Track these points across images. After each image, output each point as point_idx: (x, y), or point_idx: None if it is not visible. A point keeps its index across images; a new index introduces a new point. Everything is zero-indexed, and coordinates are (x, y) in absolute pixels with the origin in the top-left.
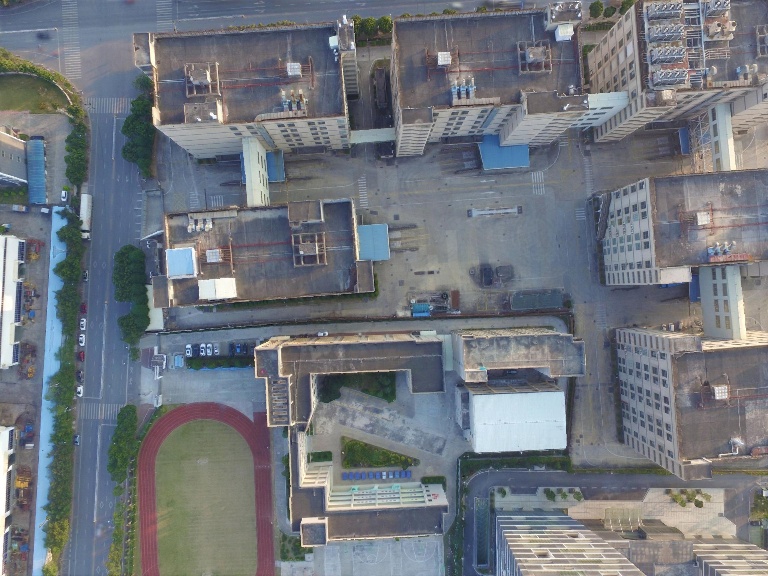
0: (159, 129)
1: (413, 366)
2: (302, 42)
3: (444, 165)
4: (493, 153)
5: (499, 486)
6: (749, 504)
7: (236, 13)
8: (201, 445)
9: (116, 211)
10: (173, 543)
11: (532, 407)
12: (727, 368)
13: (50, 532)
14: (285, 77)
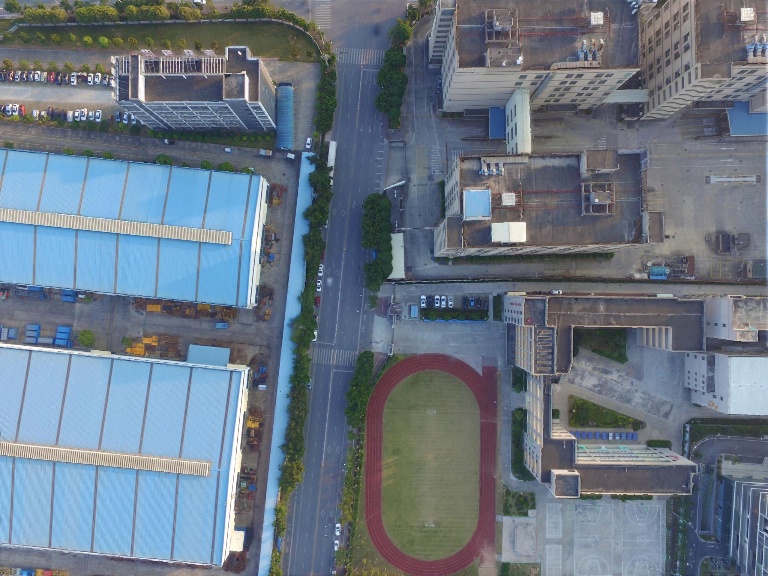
0: (457, 72)
1: (673, 324)
2: None
3: (684, 130)
4: (741, 120)
5: (726, 453)
6: None
7: None
8: (429, 396)
9: (358, 160)
10: (397, 491)
11: None
12: None
13: (289, 471)
14: (583, 27)
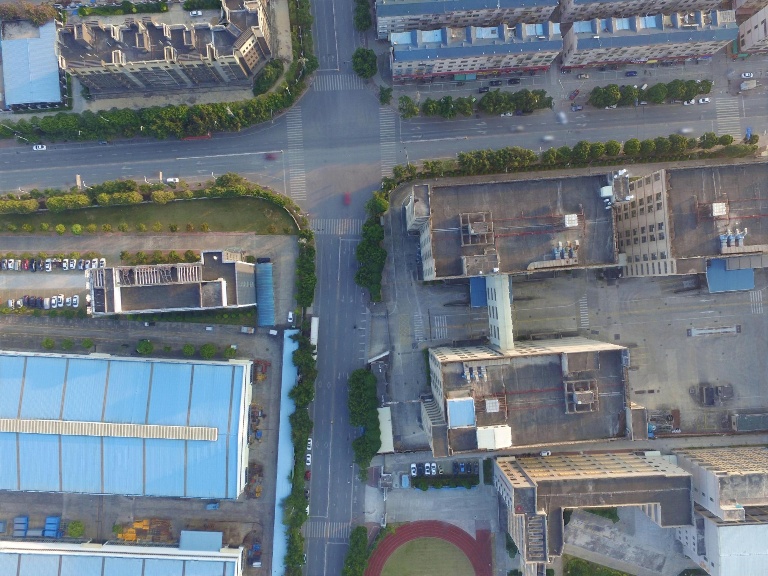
0: None
1: (661, 499)
2: (572, 190)
3: (664, 285)
4: (719, 276)
5: None
6: None
7: (459, 134)
8: (425, 563)
9: (341, 331)
10: None
11: None
12: None
13: None
14: (558, 226)
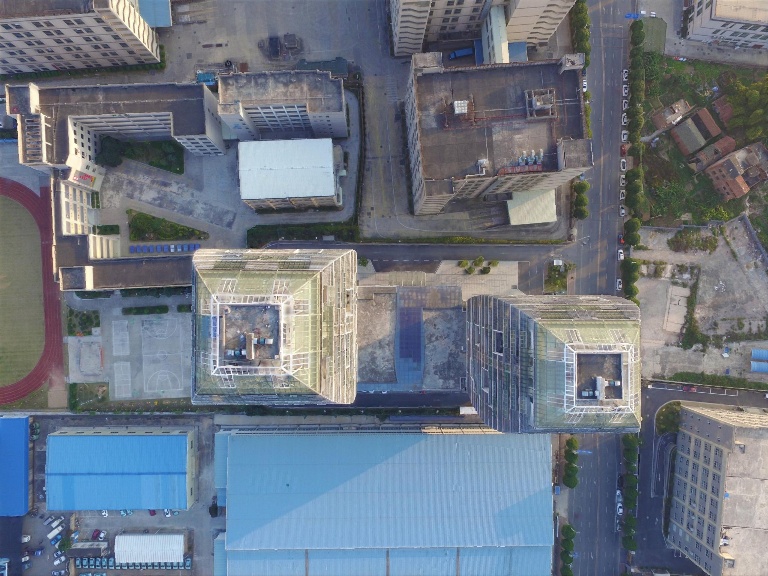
0: None
1: (175, 110)
2: None
3: None
4: None
5: None
6: (543, 277)
7: None
8: None
9: None
10: None
11: (298, 153)
12: (474, 90)
13: None
14: None
